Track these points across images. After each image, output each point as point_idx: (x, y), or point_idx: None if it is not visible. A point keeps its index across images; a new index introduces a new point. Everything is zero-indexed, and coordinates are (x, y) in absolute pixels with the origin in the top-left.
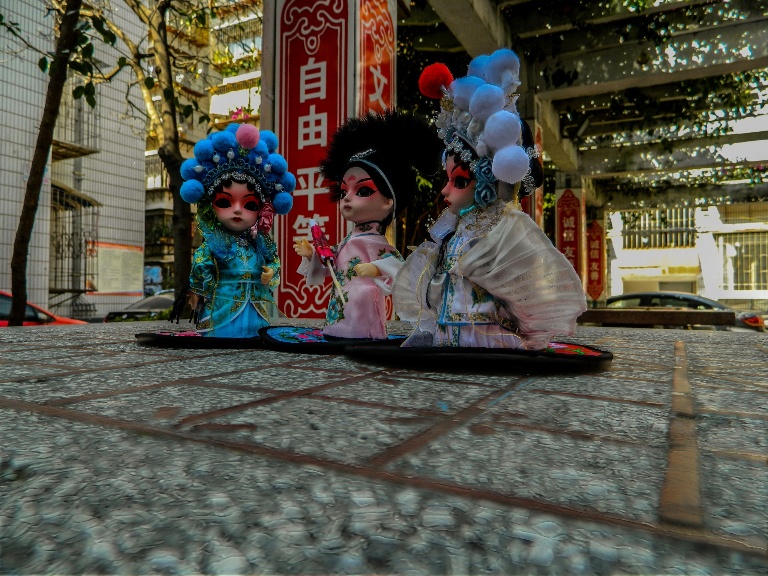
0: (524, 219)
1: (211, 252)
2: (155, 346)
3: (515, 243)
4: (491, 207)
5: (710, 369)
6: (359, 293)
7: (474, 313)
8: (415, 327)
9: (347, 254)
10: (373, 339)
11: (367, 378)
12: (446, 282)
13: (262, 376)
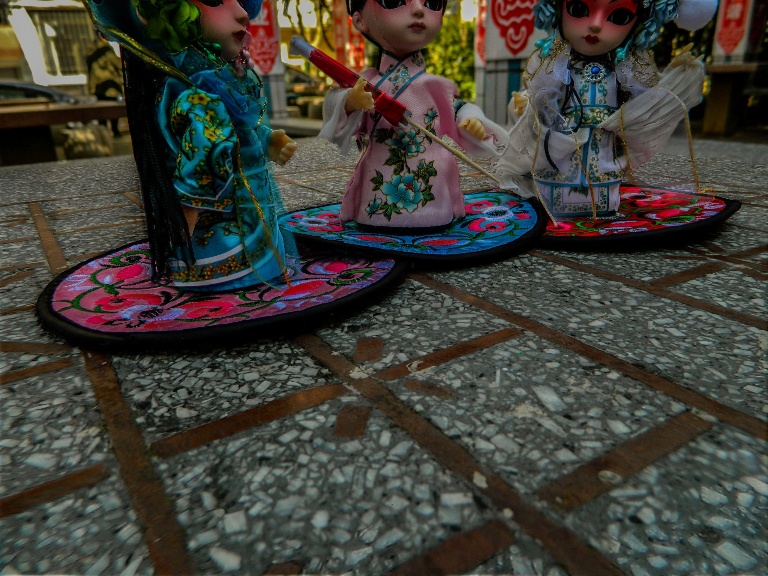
0: (701, 70)
1: (229, 113)
2: (258, 342)
3: (688, 95)
4: (644, 51)
5: (646, 184)
6: (445, 160)
7: (620, 170)
8: (539, 194)
9: (419, 103)
10: (455, 219)
11: (765, 266)
12: (588, 138)
13: (764, 303)
